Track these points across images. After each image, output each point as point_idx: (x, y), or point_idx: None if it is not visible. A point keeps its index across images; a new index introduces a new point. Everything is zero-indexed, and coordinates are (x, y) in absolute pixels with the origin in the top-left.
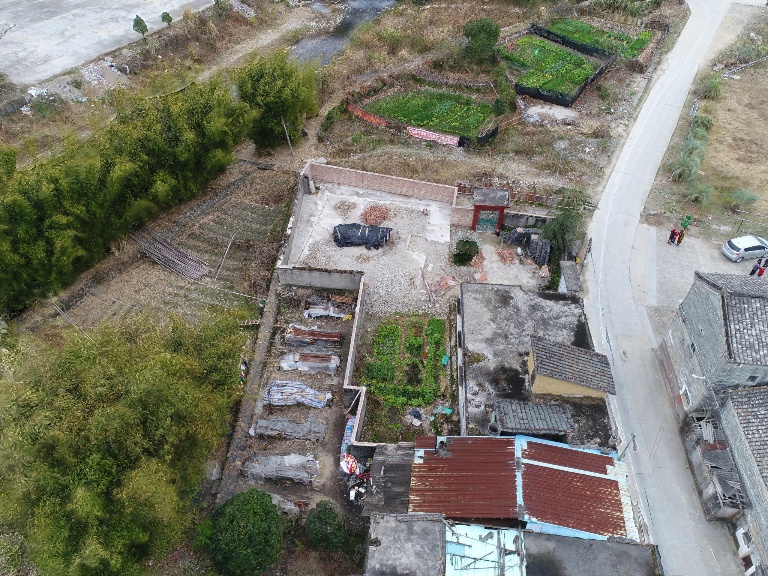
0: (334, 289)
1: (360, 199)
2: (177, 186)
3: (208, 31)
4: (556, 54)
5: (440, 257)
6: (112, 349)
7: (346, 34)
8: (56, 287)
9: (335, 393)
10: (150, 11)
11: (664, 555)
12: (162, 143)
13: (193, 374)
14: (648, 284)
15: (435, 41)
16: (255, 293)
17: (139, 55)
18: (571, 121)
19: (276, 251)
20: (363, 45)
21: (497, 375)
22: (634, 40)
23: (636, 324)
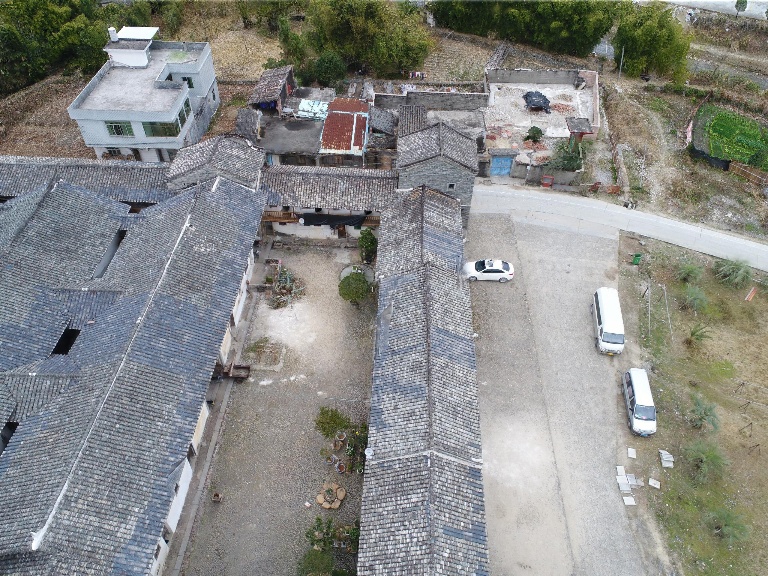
0: None
1: (579, 103)
2: (531, 27)
3: None
4: None
5: None
6: None
7: None
8: (456, 25)
9: None
10: None
11: None
12: None
13: None
14: (536, 220)
15: None
16: None
17: (715, 20)
18: None
19: None
20: None
21: None
22: None
23: (489, 206)
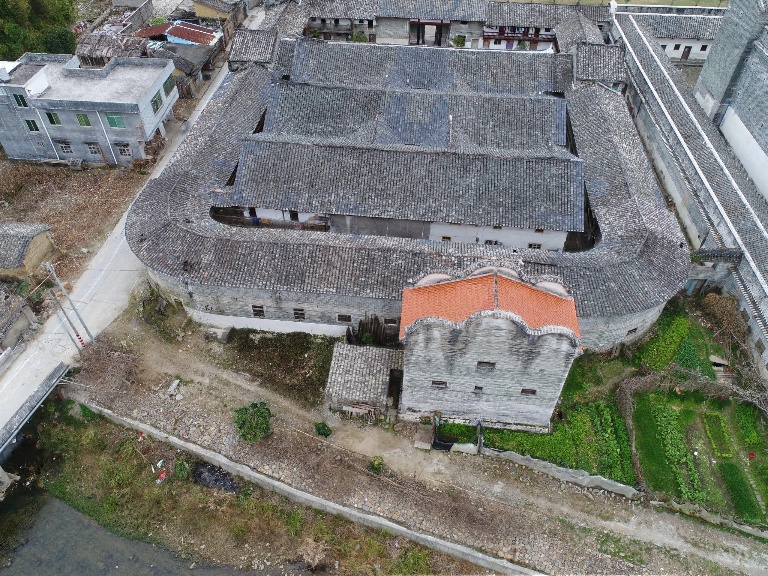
0: None
1: None
2: None
3: None
4: None
5: None
6: None
7: None
8: None
9: None
10: None
11: None
12: None
13: None
14: None
15: None
16: None
17: None
18: None
19: None
20: None
21: None
22: None
23: None
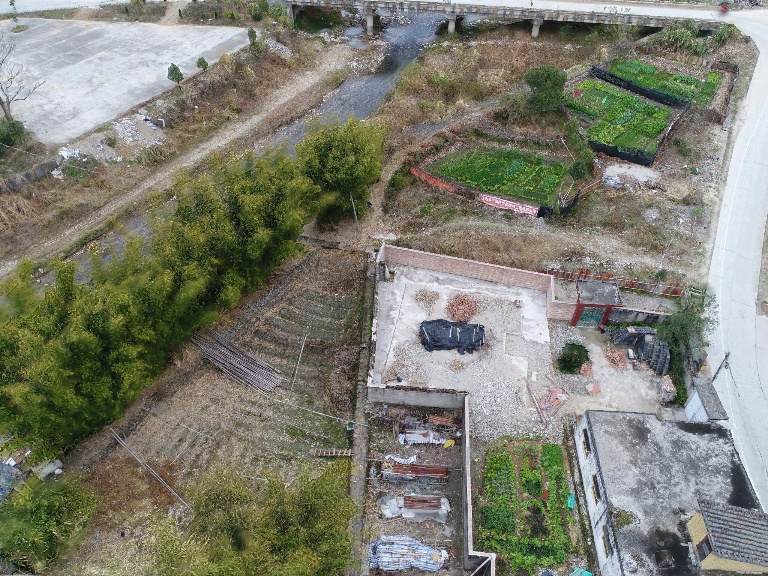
0: (430, 407)
1: (442, 287)
2: (245, 285)
3: (245, 76)
4: (623, 101)
5: (543, 362)
6: (226, 567)
7: (389, 75)
8: None
9: (450, 549)
10: (181, 53)
11: None
12: (231, 241)
13: (311, 571)
14: None
15: (490, 86)
16: (338, 410)
17: (175, 106)
18: (655, 184)
19: (357, 356)
20: (412, 90)
21: (654, 542)
22: (702, 83)
23: None
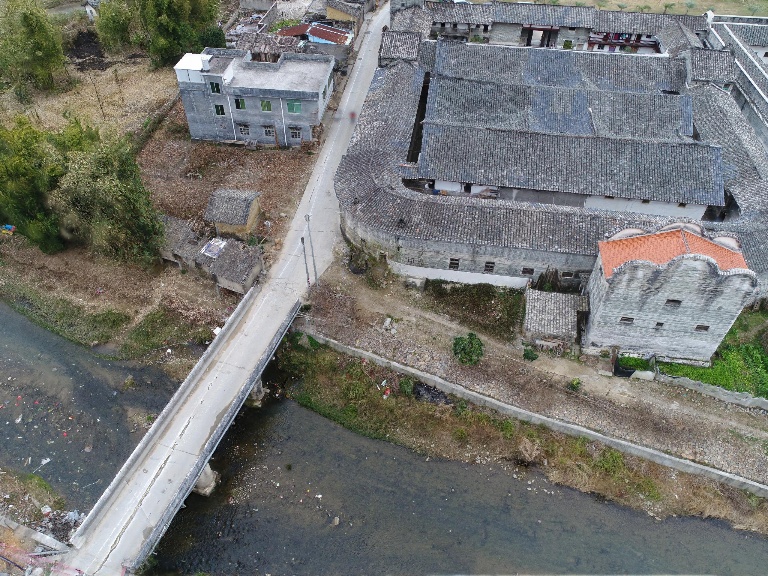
0: (264, 11)
1: None
2: None
3: None
4: None
5: None
6: None
7: None
8: None
9: None
10: None
11: (364, 63)
12: None
13: None
14: None
15: None
16: None
17: None
18: None
19: None
20: None
21: None
22: None
23: None
